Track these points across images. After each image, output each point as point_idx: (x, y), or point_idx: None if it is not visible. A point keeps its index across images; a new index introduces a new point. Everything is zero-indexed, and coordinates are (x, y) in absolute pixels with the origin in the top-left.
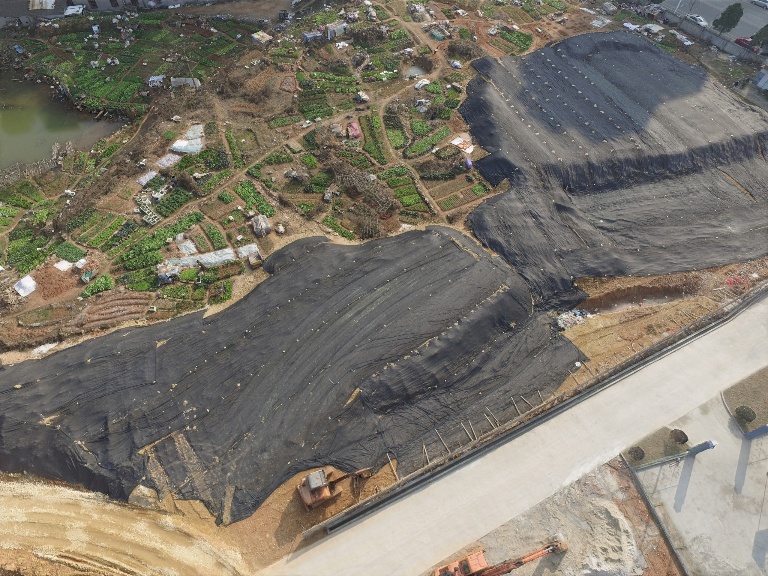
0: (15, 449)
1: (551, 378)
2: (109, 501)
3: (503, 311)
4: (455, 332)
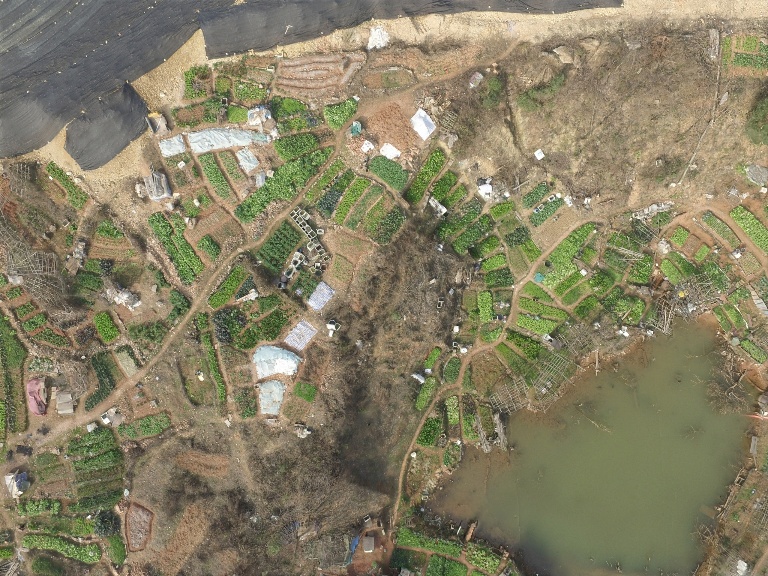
0: None
1: None
2: None
3: None
4: None
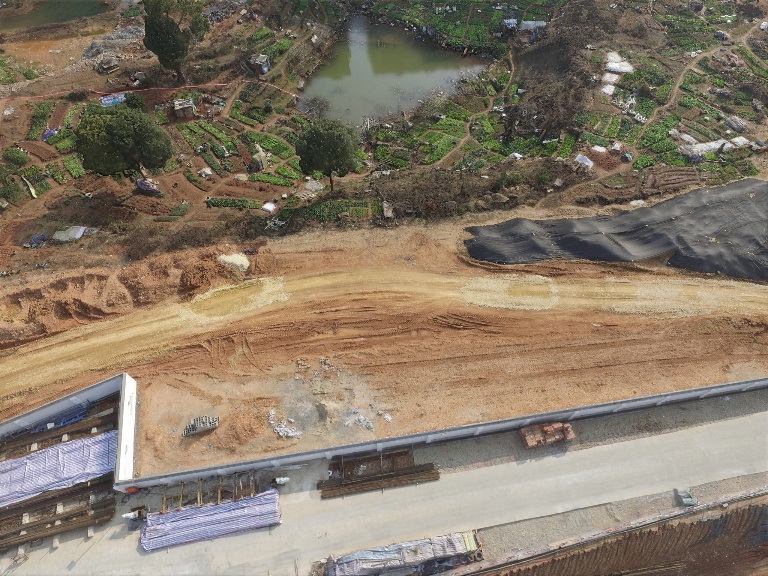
0: (709, 256)
1: None
2: None
3: None
4: None
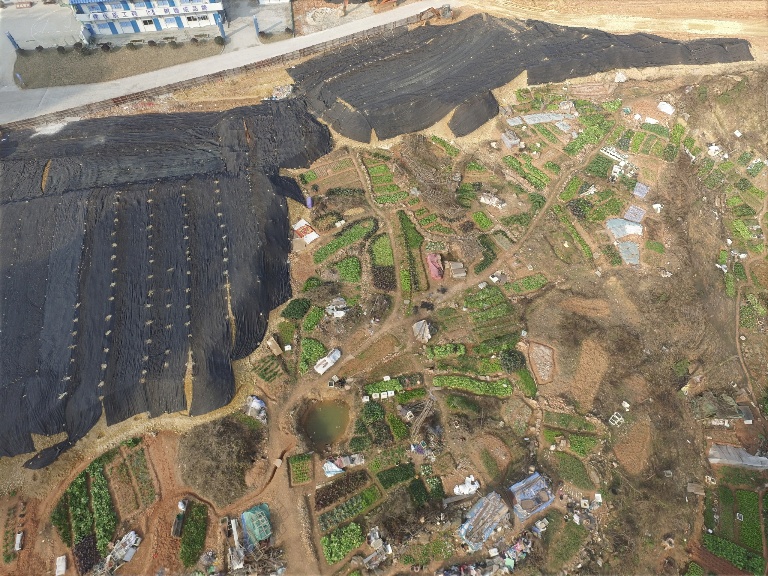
0: None
1: (314, 61)
2: None
3: None
4: None
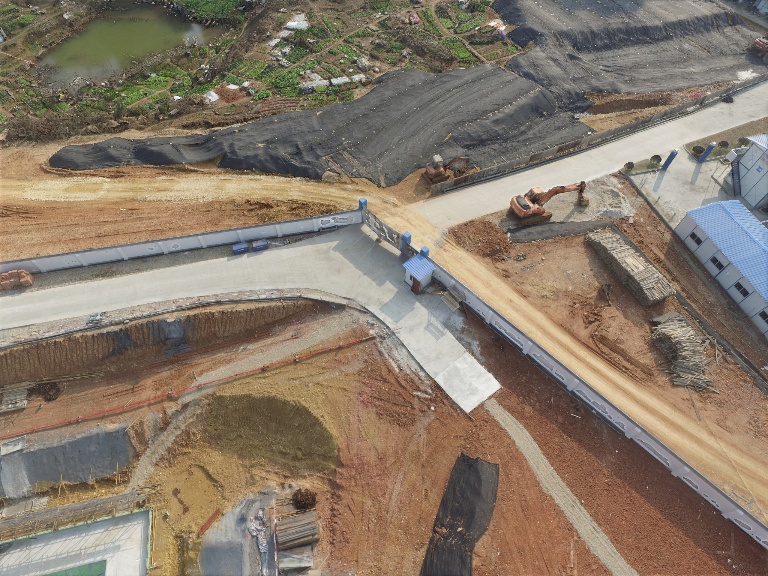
0: (246, 156)
1: (572, 139)
2: (309, 180)
3: (538, 103)
4: (509, 109)
